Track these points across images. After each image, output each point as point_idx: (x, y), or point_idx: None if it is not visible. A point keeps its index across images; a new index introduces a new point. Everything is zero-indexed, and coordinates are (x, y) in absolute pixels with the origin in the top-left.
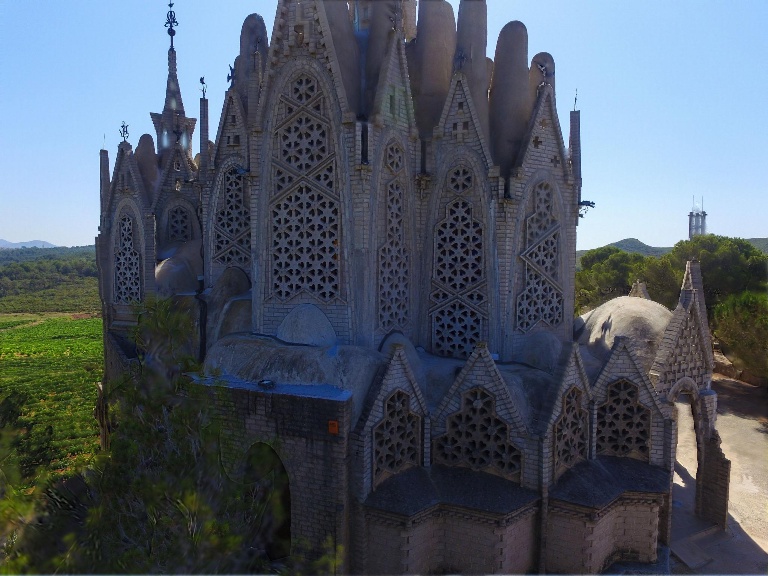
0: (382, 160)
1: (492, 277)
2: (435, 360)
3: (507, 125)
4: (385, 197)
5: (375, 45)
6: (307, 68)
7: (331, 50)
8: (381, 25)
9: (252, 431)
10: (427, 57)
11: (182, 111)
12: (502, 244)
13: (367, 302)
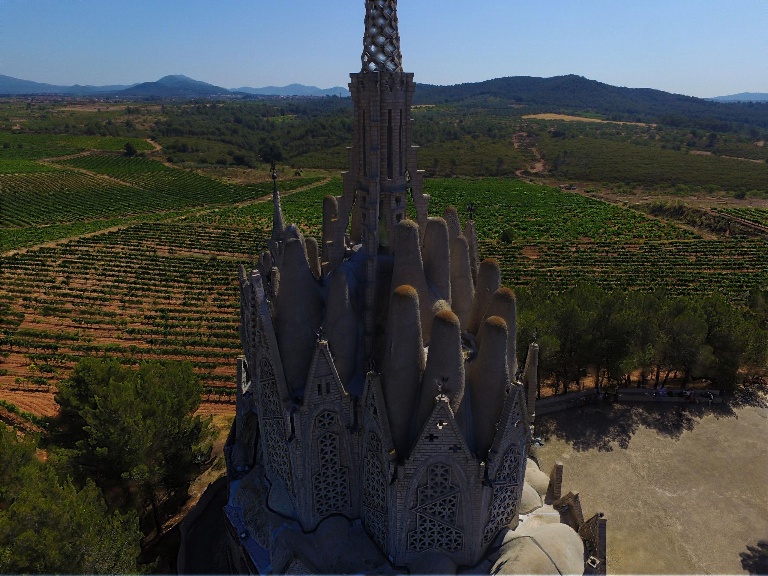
0: (313, 426)
1: (390, 515)
2: (356, 541)
3: (422, 405)
4: (317, 446)
5: (324, 325)
6: (268, 357)
7: (273, 359)
8: (328, 311)
9: None
10: None
11: None
12: (395, 501)
13: (304, 504)
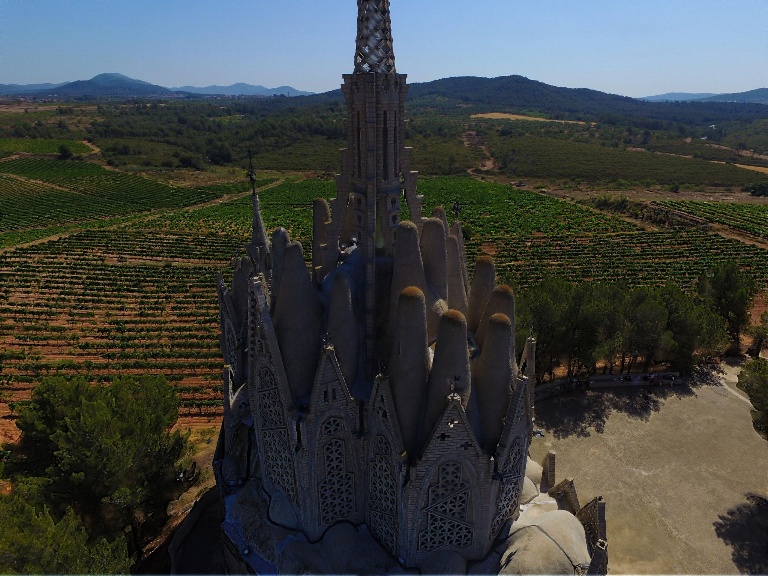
0: (319, 433)
1: (400, 517)
2: (363, 546)
3: (431, 404)
4: (323, 453)
5: None
6: (269, 366)
7: (277, 368)
8: (331, 316)
9: (243, 568)
10: (393, 303)
11: (264, 242)
12: (406, 502)
13: (310, 514)
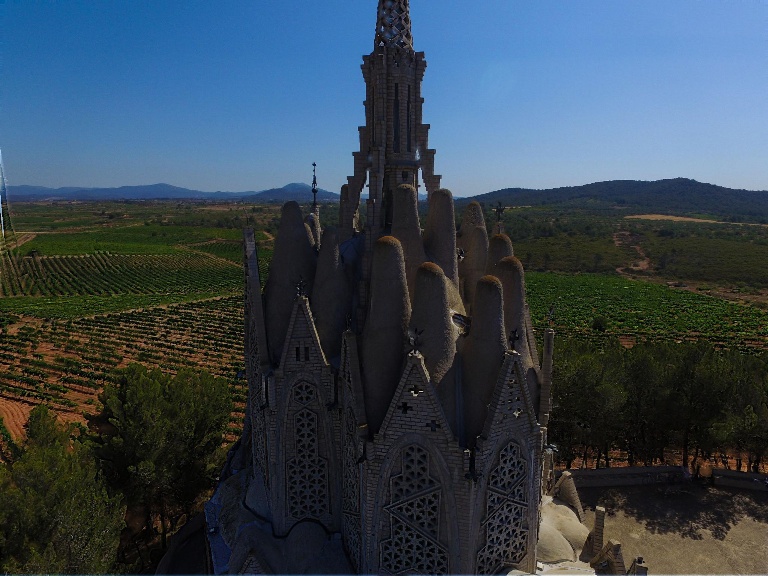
0: (289, 397)
1: (362, 515)
2: (329, 556)
3: None
4: (293, 424)
5: None
6: None
7: (255, 317)
8: (316, 272)
9: None
10: None
11: None
12: (365, 493)
13: (276, 498)
